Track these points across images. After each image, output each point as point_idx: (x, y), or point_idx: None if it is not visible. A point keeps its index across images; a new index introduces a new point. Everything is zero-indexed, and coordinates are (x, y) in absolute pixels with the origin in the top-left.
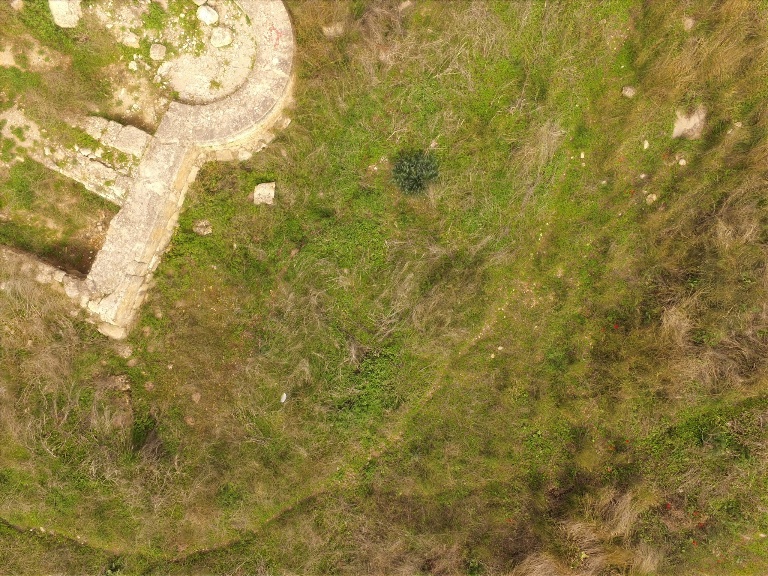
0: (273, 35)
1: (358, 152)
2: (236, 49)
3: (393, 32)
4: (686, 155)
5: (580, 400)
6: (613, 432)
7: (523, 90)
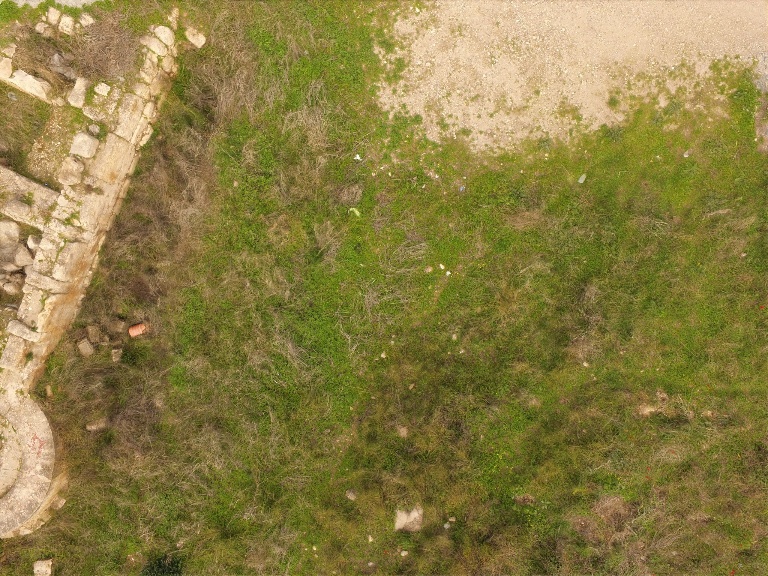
0: (36, 444)
1: (118, 542)
2: (6, 453)
3: (141, 441)
4: (407, 547)
5: None
6: None
7: (254, 499)
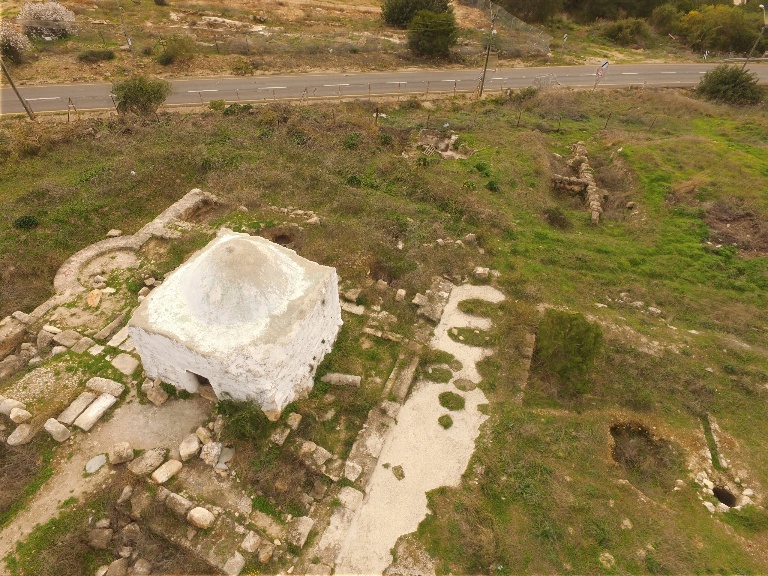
0: None
1: None
2: None
3: None
4: None
5: (7, 174)
6: (0, 167)
7: None
